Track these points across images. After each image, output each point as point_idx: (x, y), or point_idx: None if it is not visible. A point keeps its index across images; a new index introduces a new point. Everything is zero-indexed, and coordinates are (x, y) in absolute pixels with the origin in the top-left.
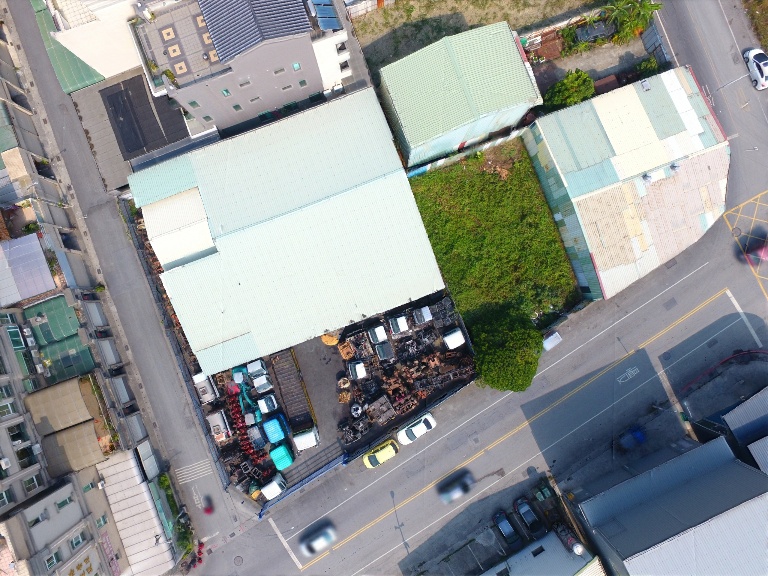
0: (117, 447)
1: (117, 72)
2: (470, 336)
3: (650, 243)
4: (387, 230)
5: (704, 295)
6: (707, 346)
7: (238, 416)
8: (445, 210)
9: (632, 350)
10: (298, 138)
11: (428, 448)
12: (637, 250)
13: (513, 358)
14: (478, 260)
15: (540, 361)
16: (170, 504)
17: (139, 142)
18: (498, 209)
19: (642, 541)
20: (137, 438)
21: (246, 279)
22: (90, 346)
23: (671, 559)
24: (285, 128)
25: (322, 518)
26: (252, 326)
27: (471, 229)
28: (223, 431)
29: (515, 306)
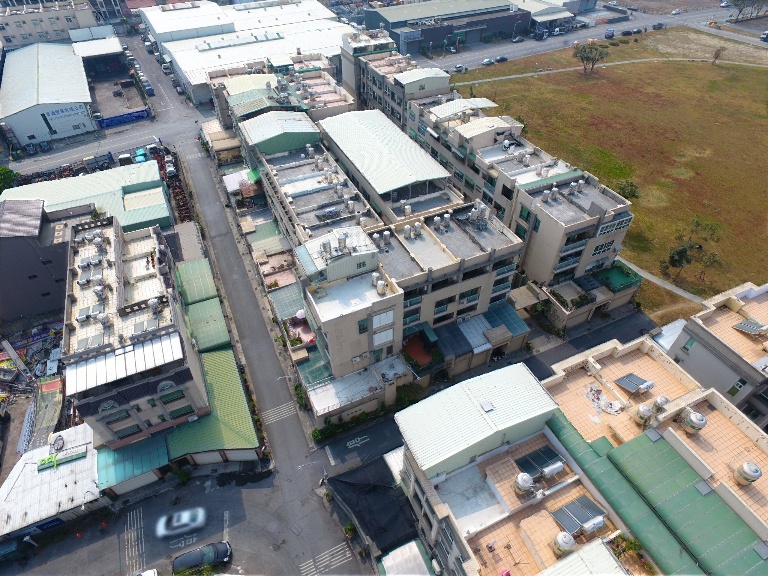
0: None
1: None
2: None
3: None
4: None
5: None
6: None
7: None
8: None
9: None
10: None
11: None
12: None
13: None
14: None
15: None
16: None
17: None
18: None
19: None
20: None
21: None
22: None
23: None
24: None
25: None
26: None
27: None
28: None
29: None
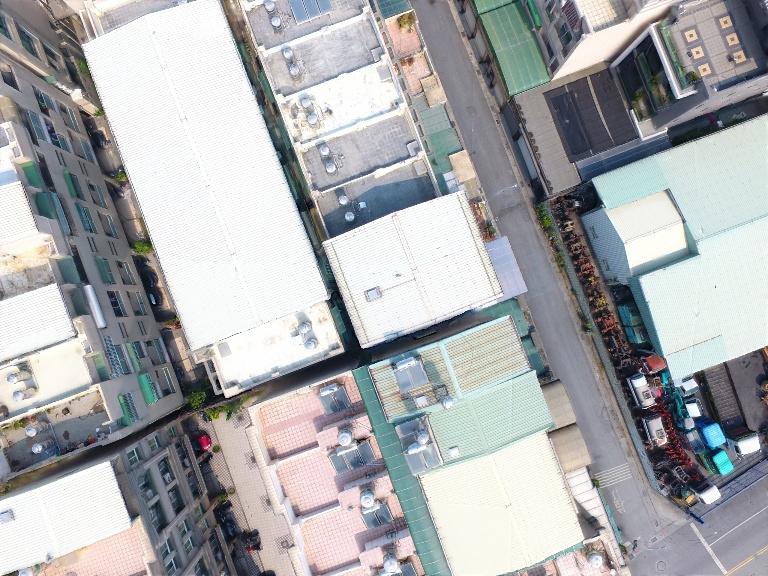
0: None
1: (565, 74)
2: None
3: None
4: None
5: None
6: None
7: None
8: None
9: None
10: (765, 140)
11: None
12: None
13: None
14: None
15: None
16: None
17: (585, 144)
18: None
19: None
20: None
21: (722, 282)
22: None
23: None
24: (751, 130)
25: (745, 523)
26: (723, 329)
27: None
28: None
29: None
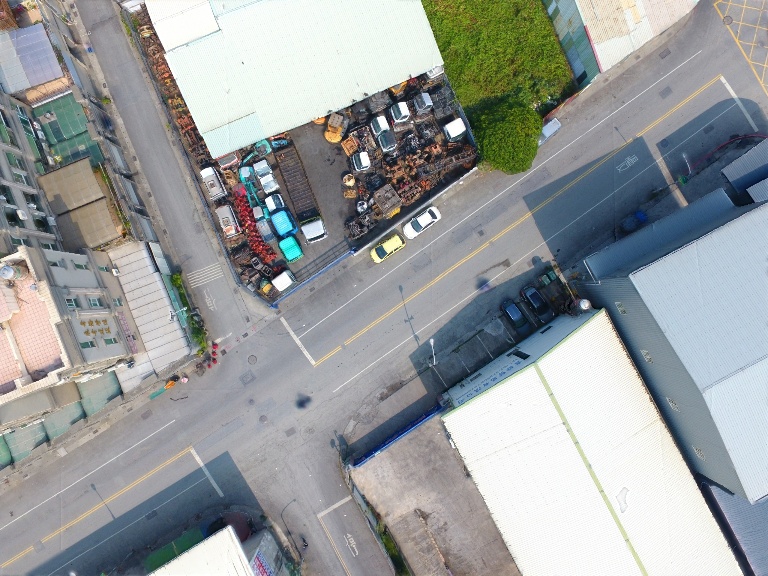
0: (129, 234)
1: None
2: (470, 124)
3: (643, 15)
4: (385, 6)
5: (699, 82)
6: (704, 132)
7: (246, 214)
8: (441, 10)
9: (630, 139)
10: None
11: (434, 242)
12: (630, 22)
13: (513, 129)
14: (475, 55)
15: (540, 153)
16: (183, 302)
17: None
18: (493, 5)
19: (646, 264)
20: (148, 237)
21: (249, 58)
22: (99, 143)
23: (675, 270)
24: None
25: (333, 315)
26: (257, 106)
27: (467, 27)
28: (232, 224)
29: (513, 96)
